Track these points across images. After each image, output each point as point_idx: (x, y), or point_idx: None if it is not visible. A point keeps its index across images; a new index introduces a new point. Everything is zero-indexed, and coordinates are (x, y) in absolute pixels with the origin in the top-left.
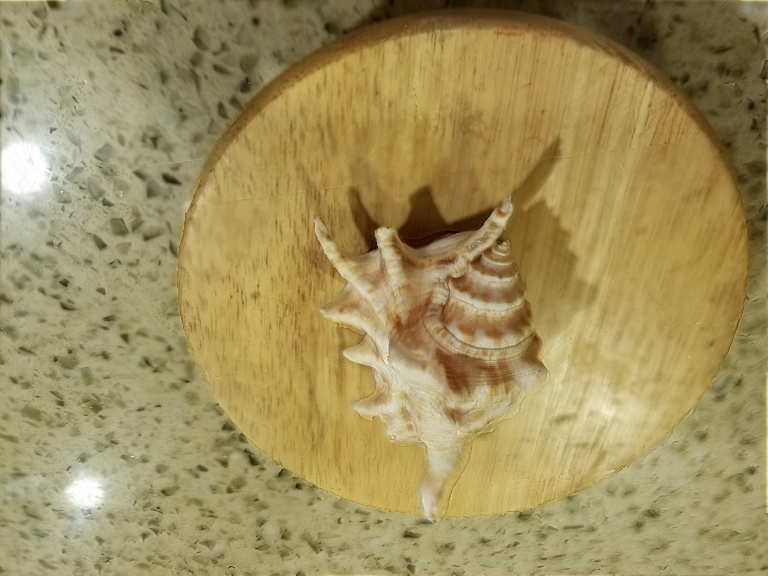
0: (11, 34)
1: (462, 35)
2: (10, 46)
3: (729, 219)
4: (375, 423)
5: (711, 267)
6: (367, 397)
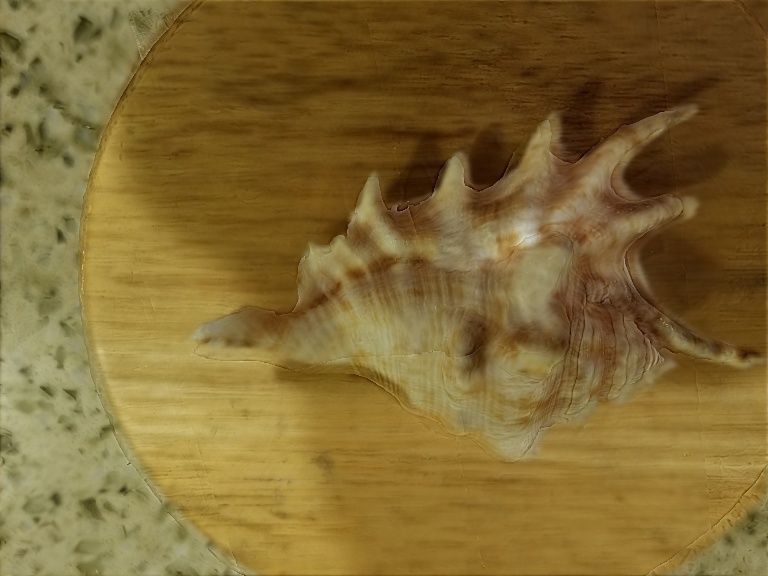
0: None
1: None
2: None
3: (620, 575)
4: (282, 209)
5: None
6: (335, 194)
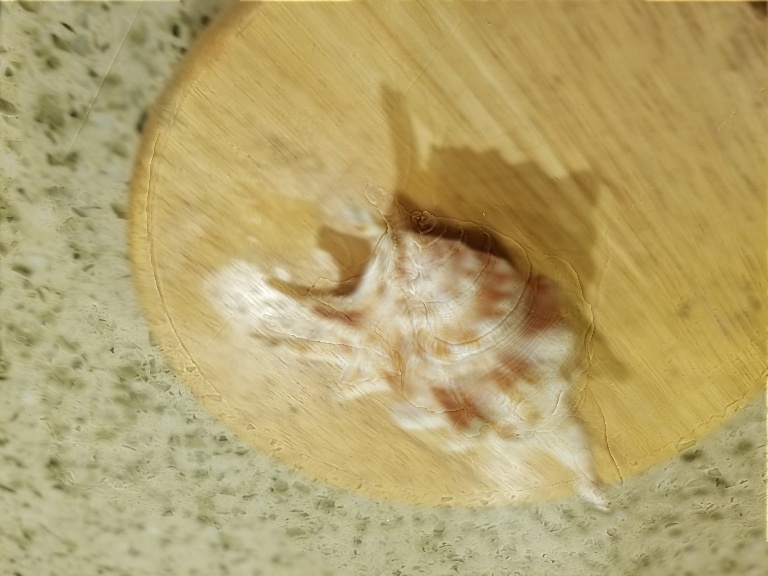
0: (29, 313)
1: (215, 66)
2: (36, 320)
3: None
4: None
5: (712, 22)
6: None
